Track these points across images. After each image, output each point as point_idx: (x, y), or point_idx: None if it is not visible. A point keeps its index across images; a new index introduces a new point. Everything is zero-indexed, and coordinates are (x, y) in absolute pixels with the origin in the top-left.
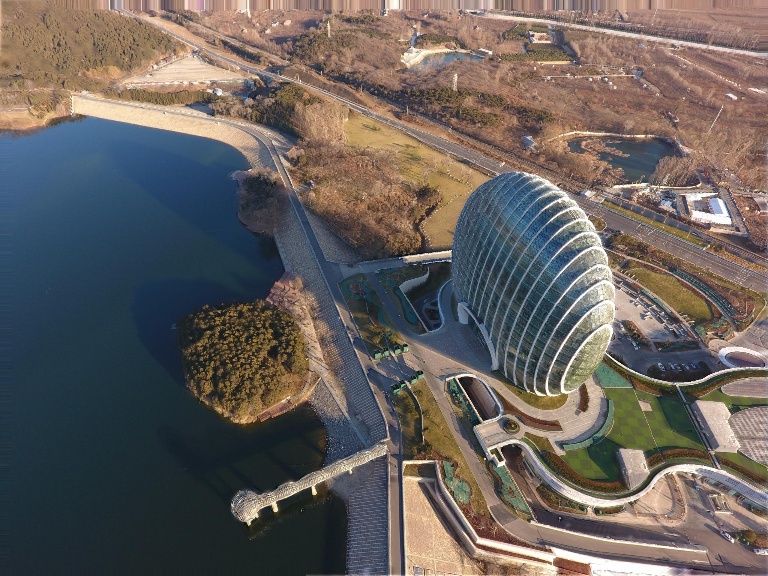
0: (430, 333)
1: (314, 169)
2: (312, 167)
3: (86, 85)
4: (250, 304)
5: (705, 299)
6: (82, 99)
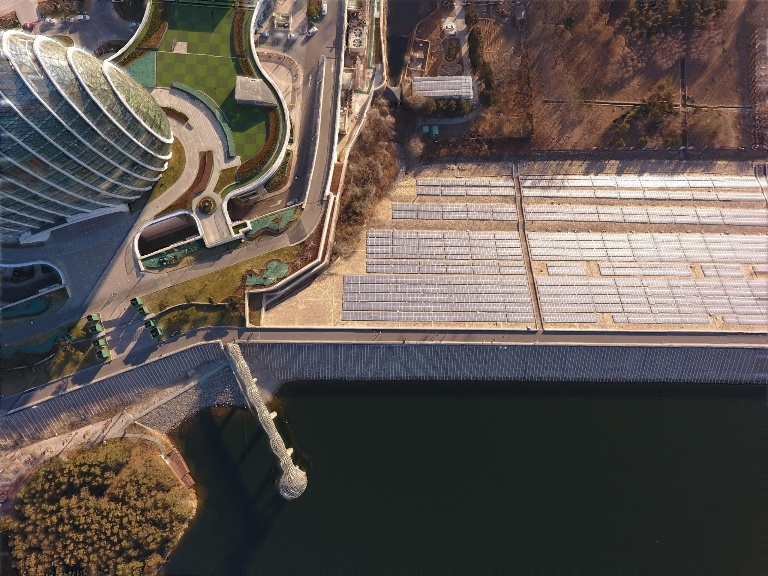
0: (66, 283)
1: None
2: None
3: None
4: (9, 541)
5: None
6: None
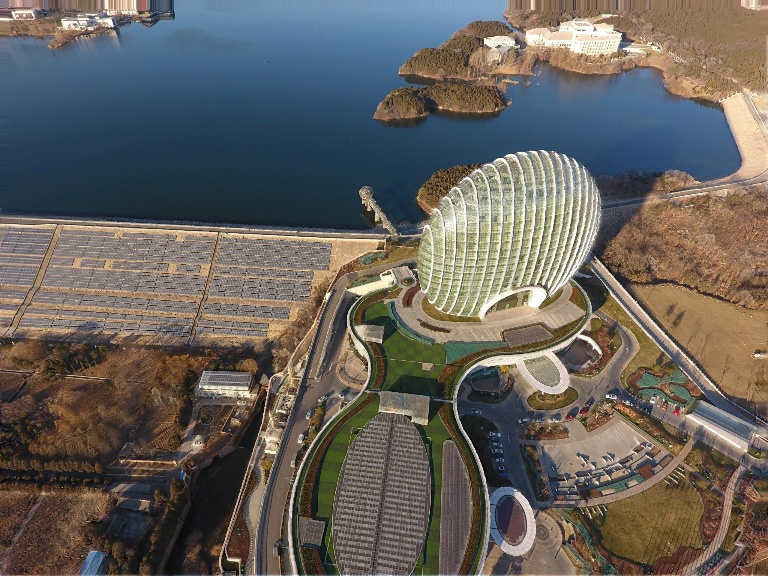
0: None
1: (725, 209)
2: (727, 208)
3: (764, 91)
4: None
5: (656, 567)
6: (741, 97)
